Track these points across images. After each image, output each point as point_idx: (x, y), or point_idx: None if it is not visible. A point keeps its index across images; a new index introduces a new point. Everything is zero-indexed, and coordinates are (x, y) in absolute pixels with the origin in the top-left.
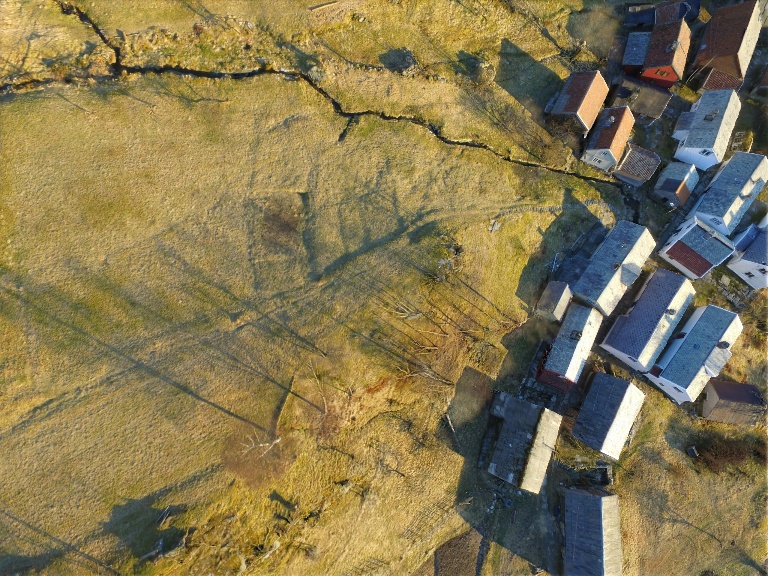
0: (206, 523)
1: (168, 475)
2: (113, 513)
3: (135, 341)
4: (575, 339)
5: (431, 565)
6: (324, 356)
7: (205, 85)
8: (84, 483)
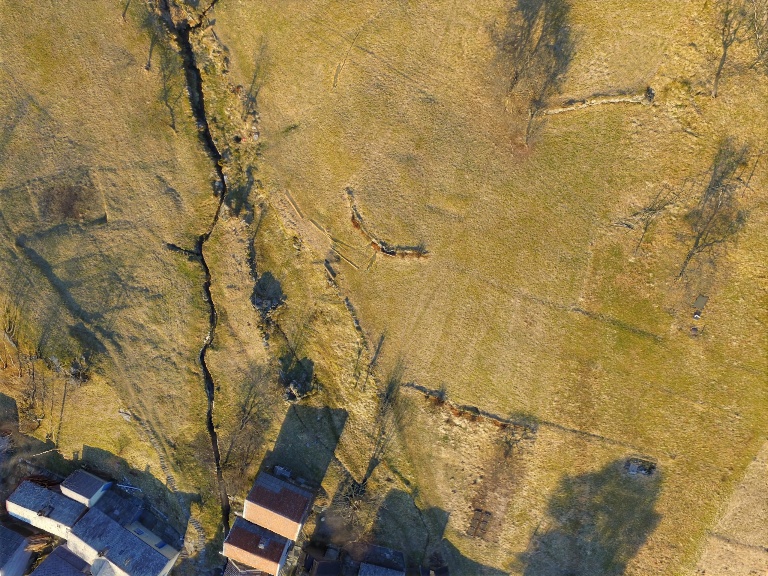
0: None
1: None
2: None
3: None
4: None
5: None
6: None
7: (185, 109)
8: None
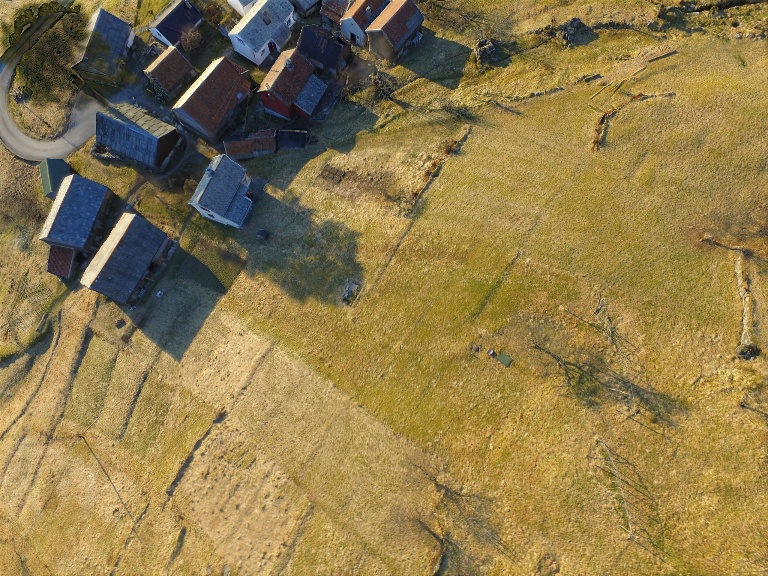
0: None
1: None
2: None
3: None
4: None
5: None
6: None
7: None
8: None
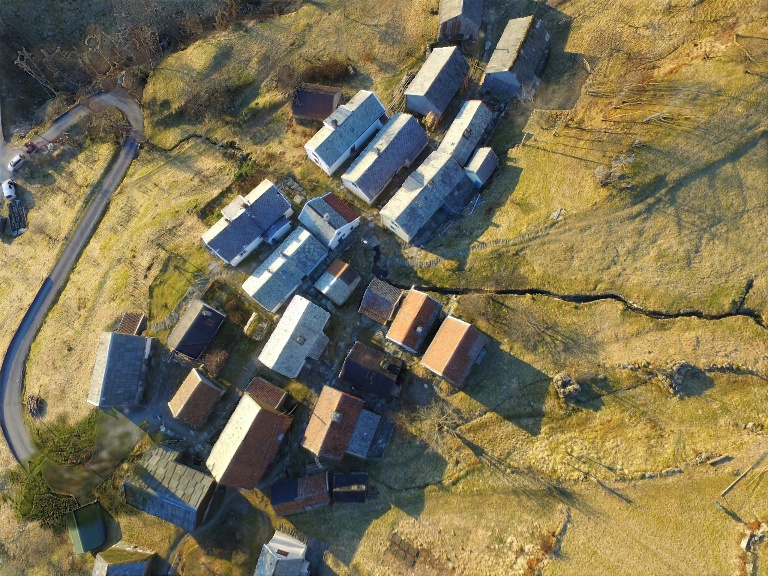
0: None
1: None
2: None
3: None
4: None
5: None
6: (748, 70)
7: None
8: None
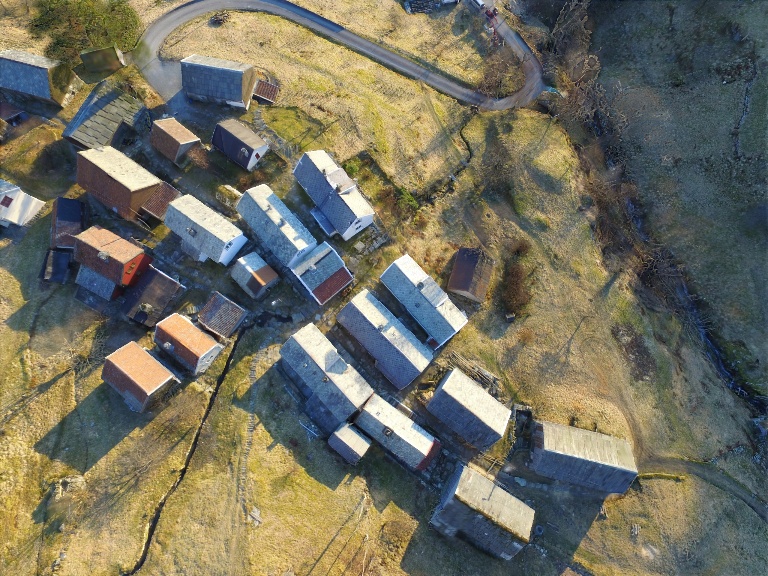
0: None
1: None
2: None
3: None
4: (391, 434)
5: None
6: None
7: None
8: None
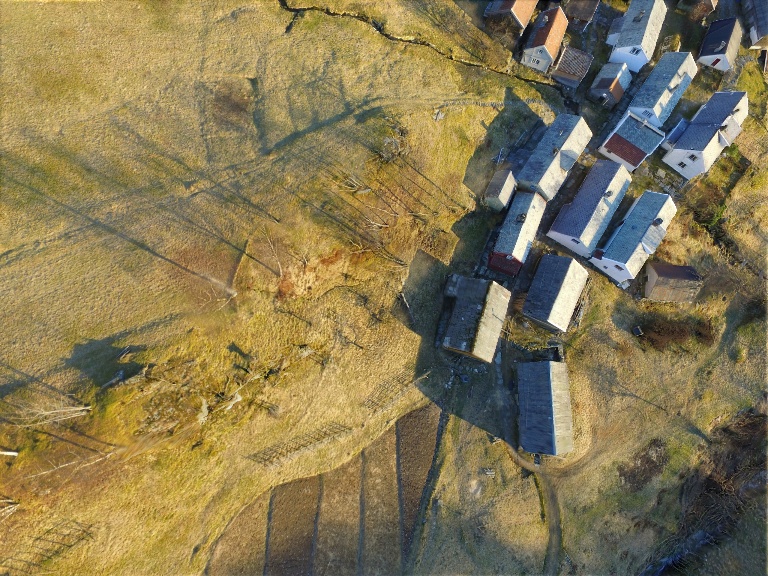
0: (166, 362)
1: (128, 320)
2: (74, 351)
3: (92, 203)
4: (520, 222)
5: (393, 434)
6: (277, 222)
7: None
8: (45, 323)
